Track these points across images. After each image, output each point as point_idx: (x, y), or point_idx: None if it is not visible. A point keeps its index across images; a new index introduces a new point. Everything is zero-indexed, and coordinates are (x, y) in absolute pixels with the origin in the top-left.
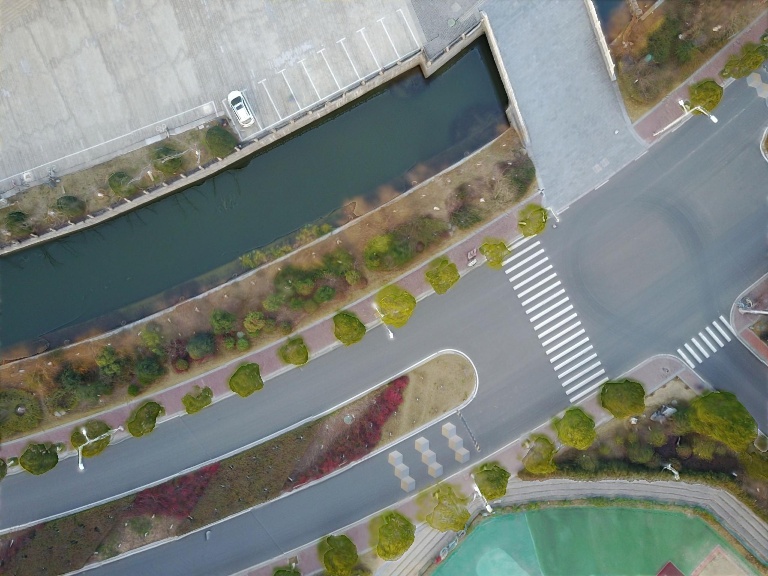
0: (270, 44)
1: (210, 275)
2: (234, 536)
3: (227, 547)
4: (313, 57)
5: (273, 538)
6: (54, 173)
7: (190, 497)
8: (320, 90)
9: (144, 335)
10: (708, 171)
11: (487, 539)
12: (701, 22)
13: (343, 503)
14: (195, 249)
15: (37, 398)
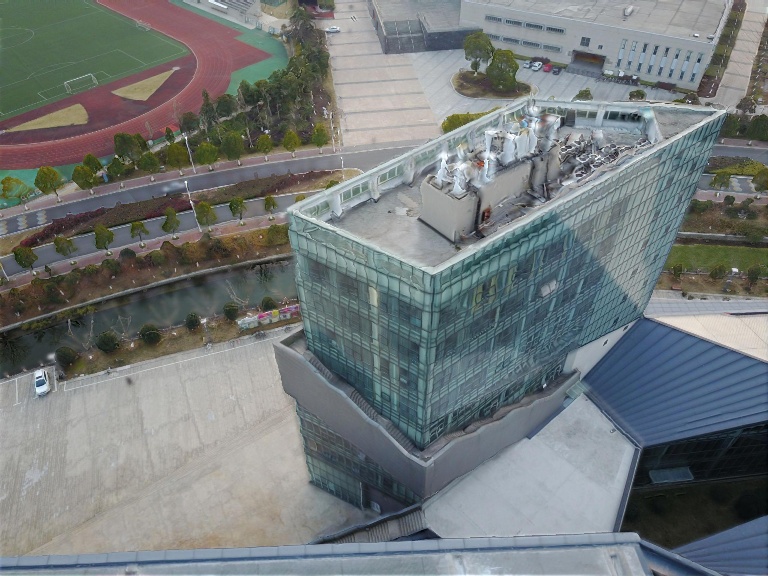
0: None
1: (122, 304)
2: (151, 195)
3: (157, 192)
4: None
5: (130, 195)
6: None
7: (168, 205)
8: None
9: (157, 254)
10: None
11: (15, 200)
12: None
13: (83, 206)
14: (139, 331)
15: (250, 242)
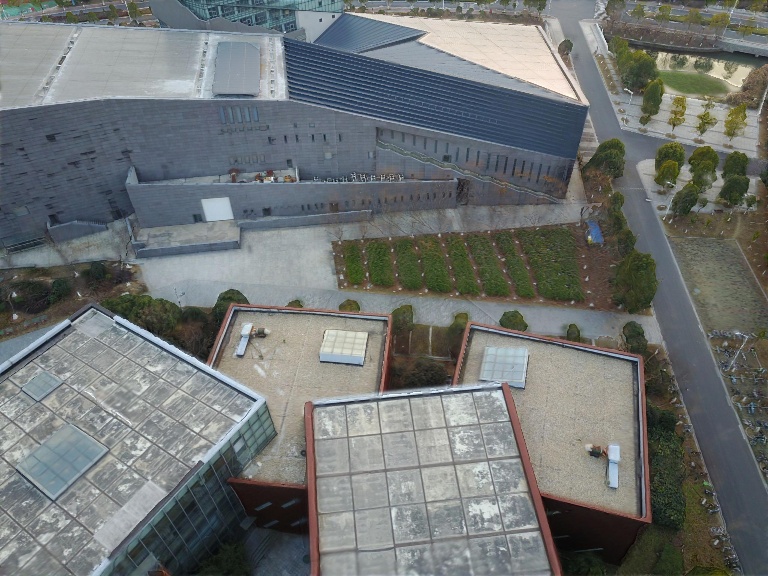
0: None
1: None
2: None
3: None
4: None
5: None
6: None
7: None
8: None
9: None
10: None
11: None
12: None
13: None
14: None
15: None
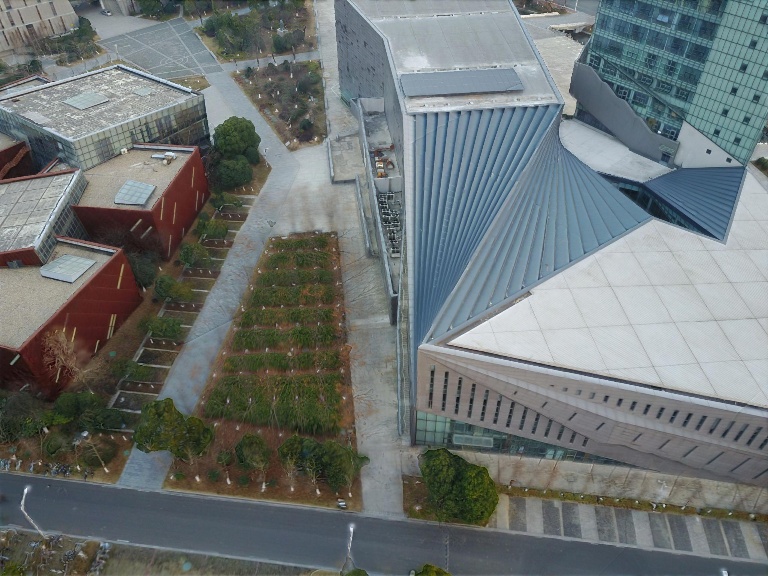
0: None
1: None
2: None
3: None
4: None
5: None
6: None
7: None
8: None
9: None
10: (583, 5)
11: None
12: (536, 4)
13: None
14: None
15: None
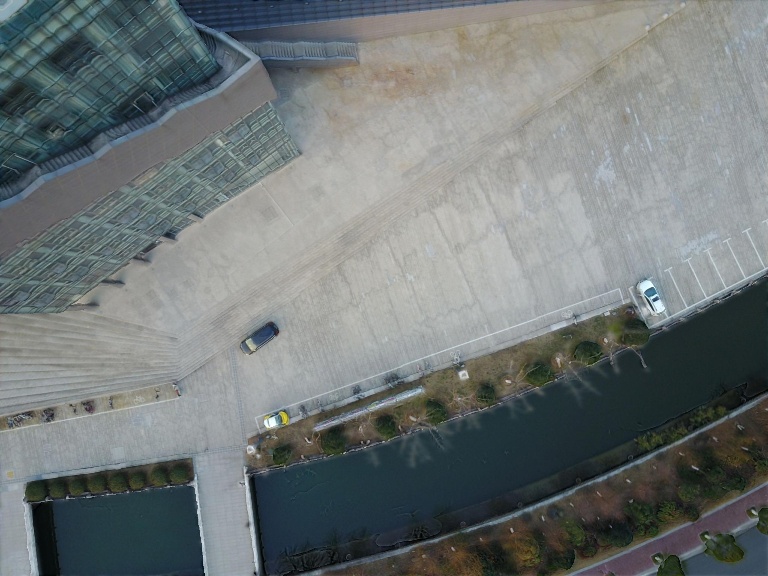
0: (677, 233)
1: (604, 456)
2: None
3: None
4: (719, 246)
5: None
6: (459, 358)
7: None
8: (726, 279)
9: (573, 531)
10: None
11: None
12: None
13: None
14: (571, 422)
15: None
